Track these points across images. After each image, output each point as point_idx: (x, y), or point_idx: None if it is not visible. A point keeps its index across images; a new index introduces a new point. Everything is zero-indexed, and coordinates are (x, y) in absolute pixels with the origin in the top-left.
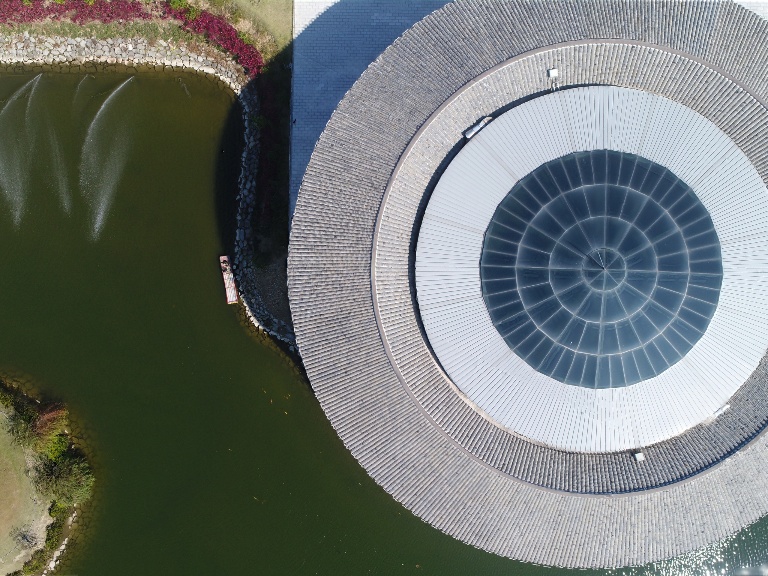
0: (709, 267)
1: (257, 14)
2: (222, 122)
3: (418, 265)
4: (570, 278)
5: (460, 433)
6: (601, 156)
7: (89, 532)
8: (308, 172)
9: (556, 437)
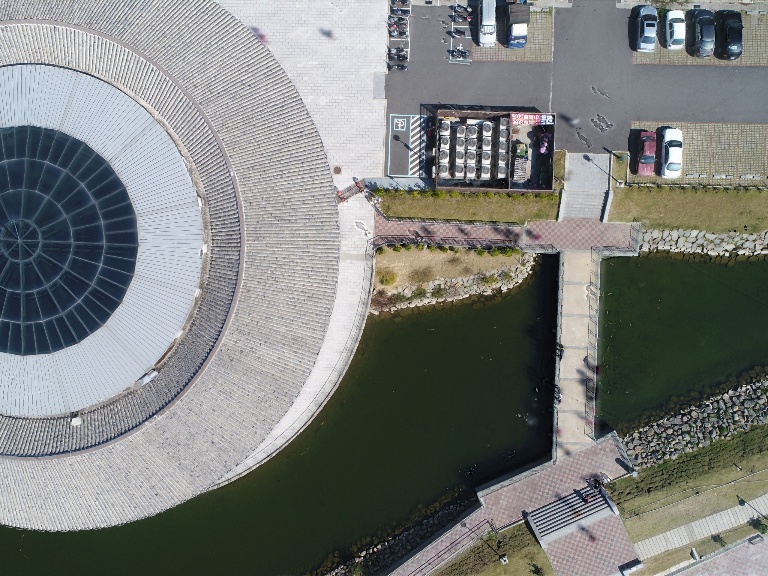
0: (124, 238)
1: None
2: None
3: None
4: None
5: None
6: (23, 132)
7: None
8: None
9: None
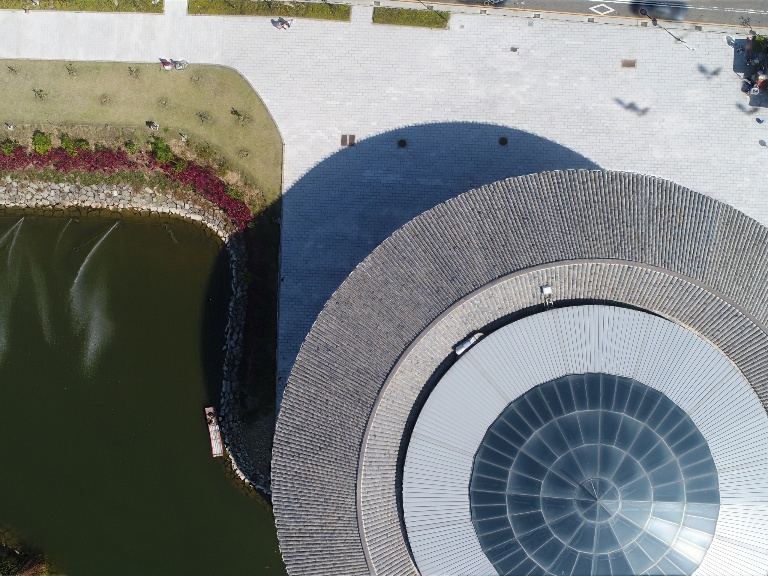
0: (706, 497)
1: (245, 168)
2: (209, 269)
3: (405, 485)
4: (562, 507)
5: None
6: (595, 380)
7: None
8: (293, 374)
9: None
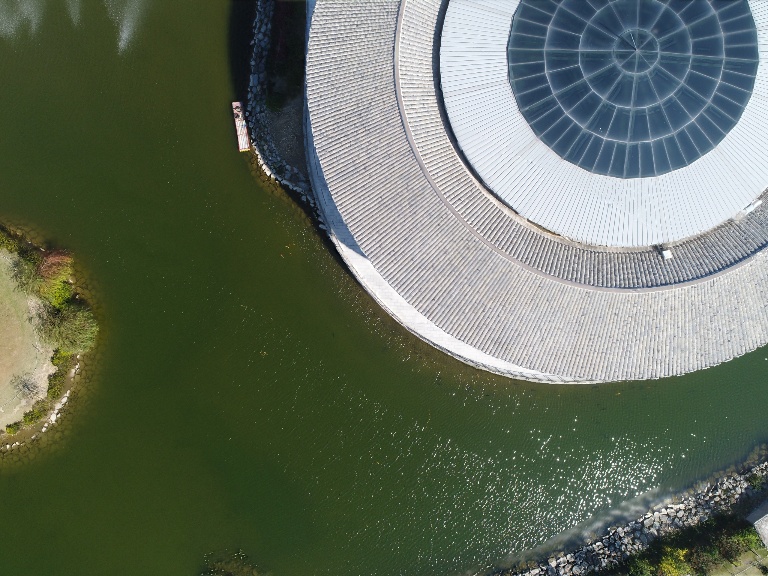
0: (745, 52)
1: None
2: None
3: (443, 50)
4: (601, 60)
5: (482, 225)
6: None
7: (92, 386)
8: None
9: (582, 230)
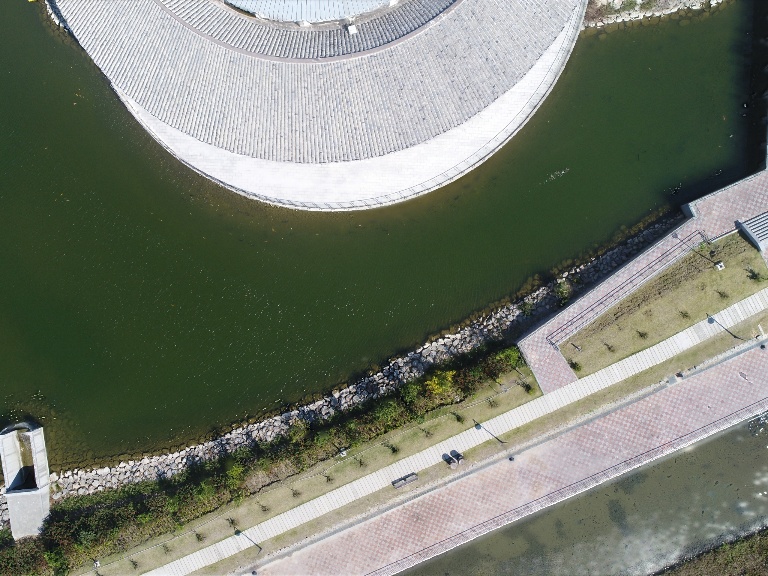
0: None
1: None
2: None
3: None
4: None
5: (175, 4)
6: None
7: None
8: None
9: (268, 6)
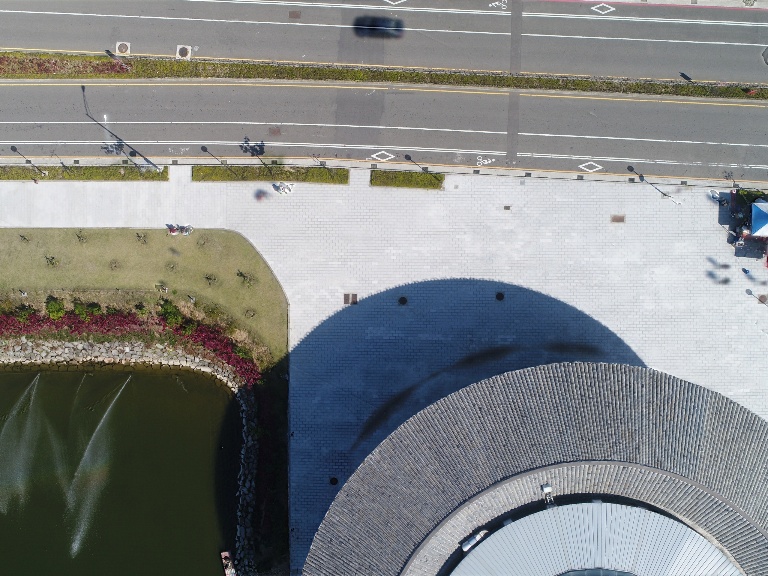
0: None
1: (252, 327)
2: (220, 417)
3: None
4: None
5: None
6: (596, 575)
7: None
8: (308, 562)
9: None
